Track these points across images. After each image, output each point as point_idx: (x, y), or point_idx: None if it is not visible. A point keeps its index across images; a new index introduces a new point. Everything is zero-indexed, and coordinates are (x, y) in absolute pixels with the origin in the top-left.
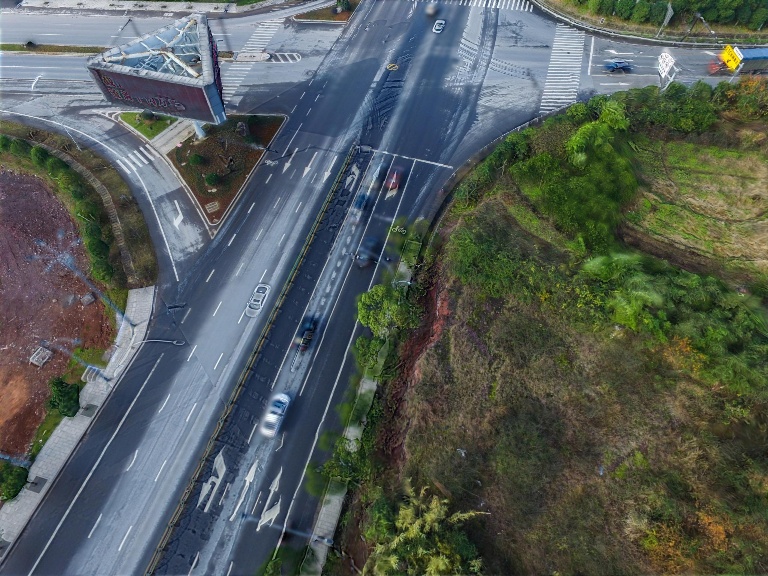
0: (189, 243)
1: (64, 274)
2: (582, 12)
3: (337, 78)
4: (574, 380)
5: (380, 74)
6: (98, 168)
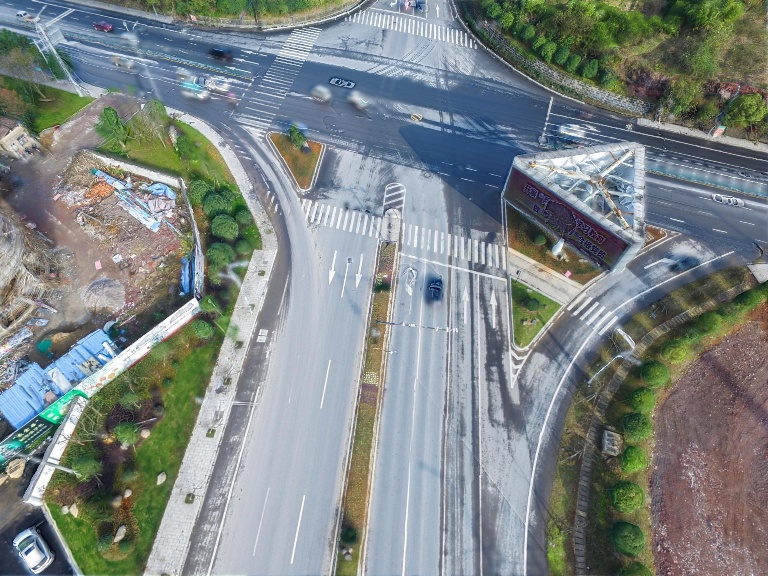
0: (693, 249)
1: (766, 343)
2: (340, 2)
3: (436, 155)
4: (763, 44)
5: (428, 126)
6: (619, 349)
